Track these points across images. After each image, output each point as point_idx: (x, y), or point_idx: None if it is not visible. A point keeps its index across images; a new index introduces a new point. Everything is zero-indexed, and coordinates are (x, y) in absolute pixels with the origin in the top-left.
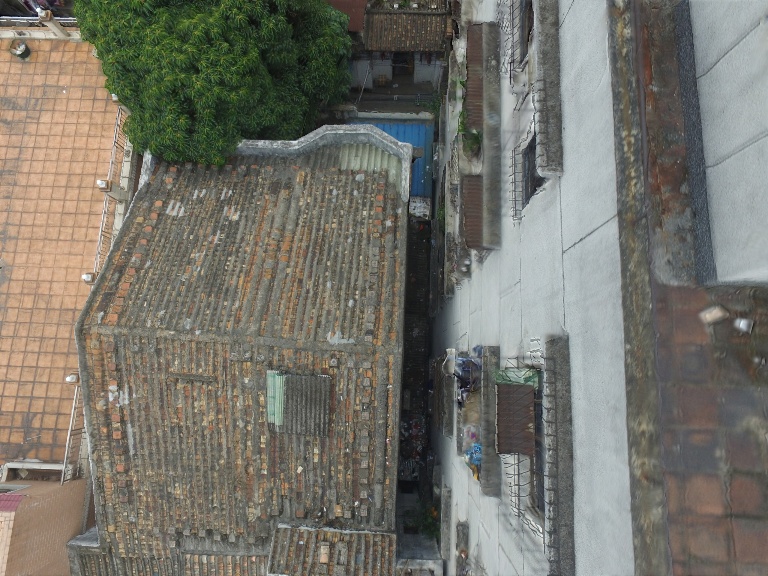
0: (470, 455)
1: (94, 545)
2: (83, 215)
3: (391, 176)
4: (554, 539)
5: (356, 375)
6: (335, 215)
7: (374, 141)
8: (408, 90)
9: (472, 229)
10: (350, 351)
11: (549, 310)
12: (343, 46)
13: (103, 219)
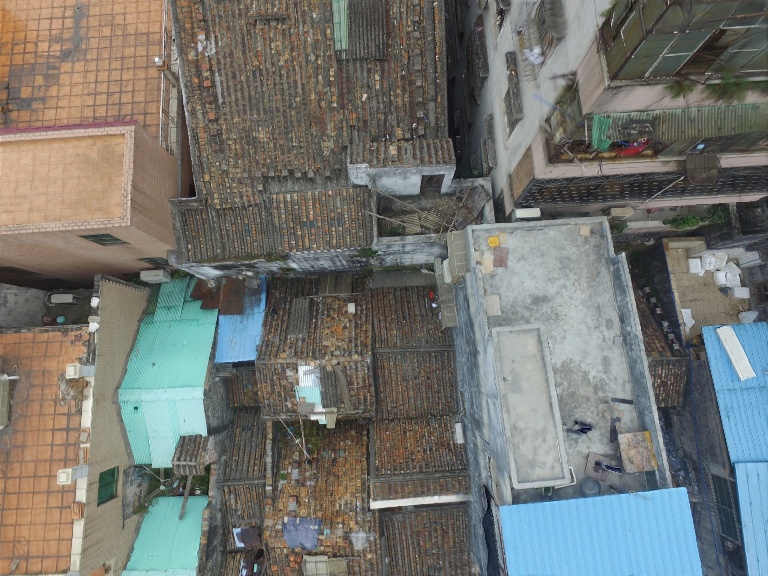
0: None
1: (192, 198)
2: None
3: None
4: None
5: None
6: None
7: None
8: None
9: None
10: None
11: None
12: None
13: None
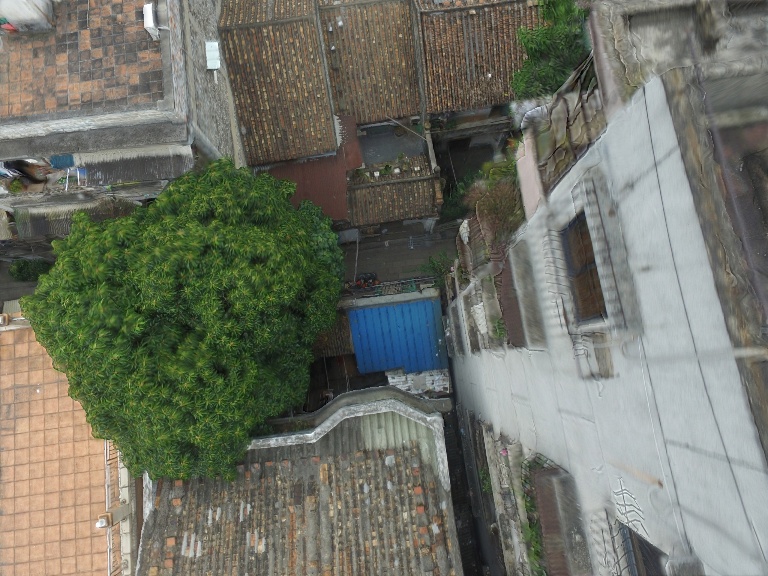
0: None
1: None
2: (84, 539)
3: (424, 453)
4: None
5: None
6: (373, 524)
7: None
8: (398, 234)
9: None
10: None
11: None
12: (335, 264)
13: (109, 559)
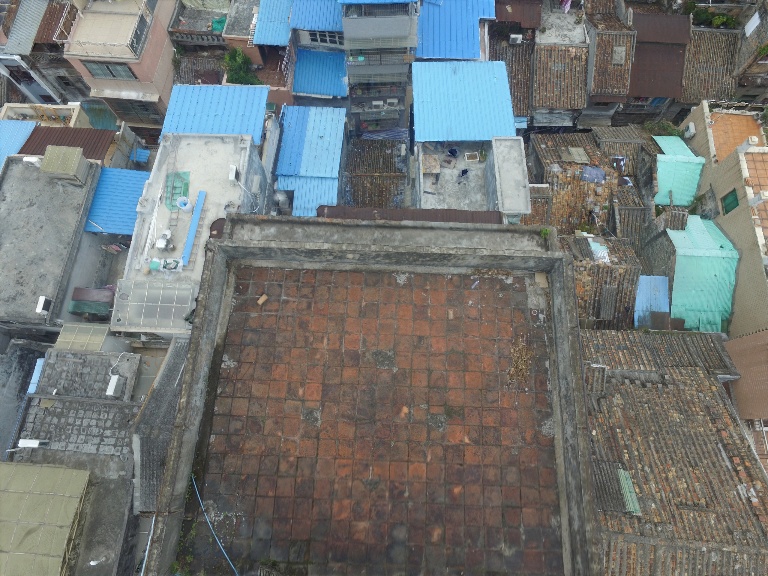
0: None
1: (721, 376)
2: None
3: None
4: None
5: None
6: None
7: None
8: None
9: None
10: None
11: None
12: None
13: None
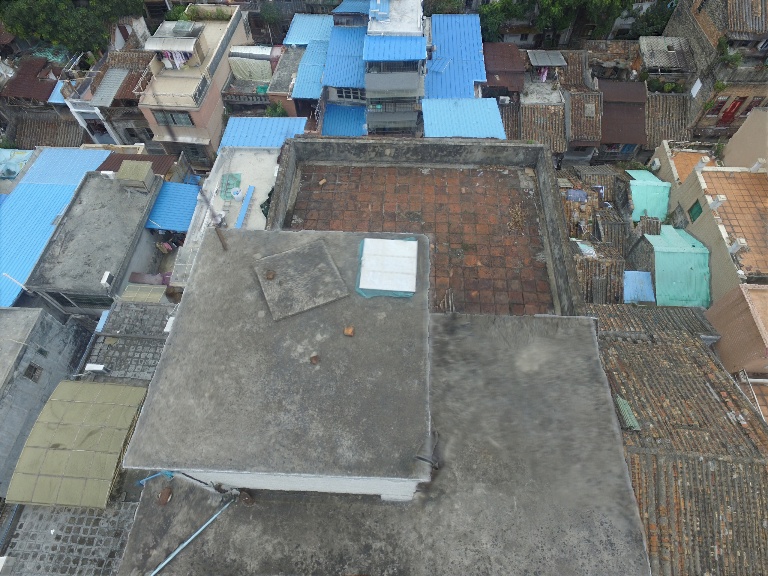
0: None
1: (704, 336)
2: None
3: None
4: None
5: None
6: None
7: None
8: None
9: None
10: None
11: None
12: None
13: None
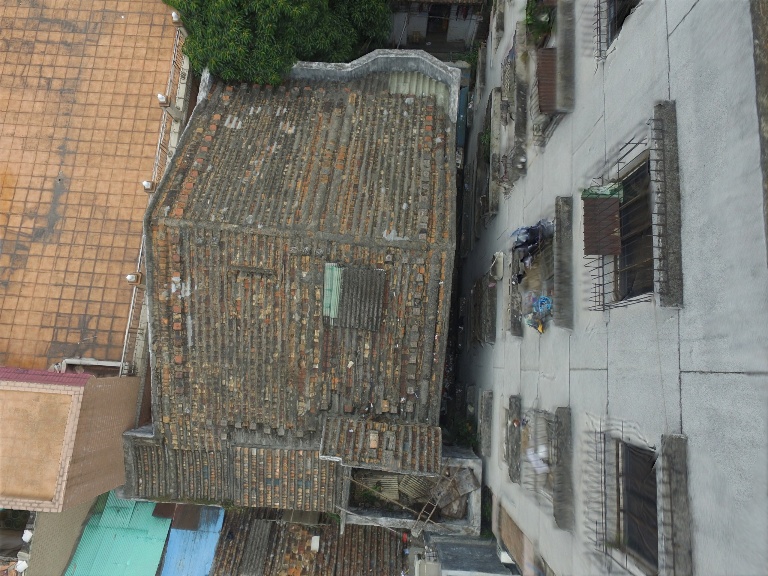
0: (533, 313)
1: (148, 436)
2: (139, 133)
3: (439, 100)
4: (664, 262)
5: (410, 271)
6: (386, 132)
7: (423, 67)
8: (441, 48)
9: (545, 95)
10: (405, 247)
11: (648, 101)
12: None
13: (162, 133)
